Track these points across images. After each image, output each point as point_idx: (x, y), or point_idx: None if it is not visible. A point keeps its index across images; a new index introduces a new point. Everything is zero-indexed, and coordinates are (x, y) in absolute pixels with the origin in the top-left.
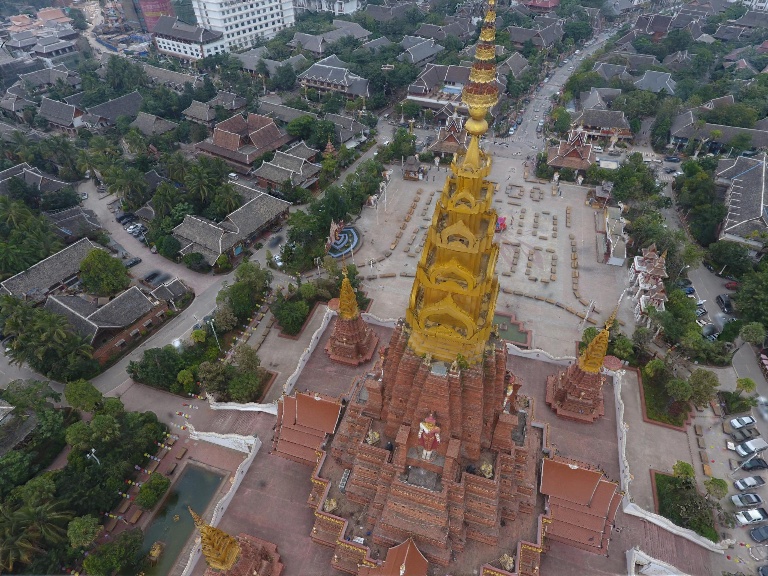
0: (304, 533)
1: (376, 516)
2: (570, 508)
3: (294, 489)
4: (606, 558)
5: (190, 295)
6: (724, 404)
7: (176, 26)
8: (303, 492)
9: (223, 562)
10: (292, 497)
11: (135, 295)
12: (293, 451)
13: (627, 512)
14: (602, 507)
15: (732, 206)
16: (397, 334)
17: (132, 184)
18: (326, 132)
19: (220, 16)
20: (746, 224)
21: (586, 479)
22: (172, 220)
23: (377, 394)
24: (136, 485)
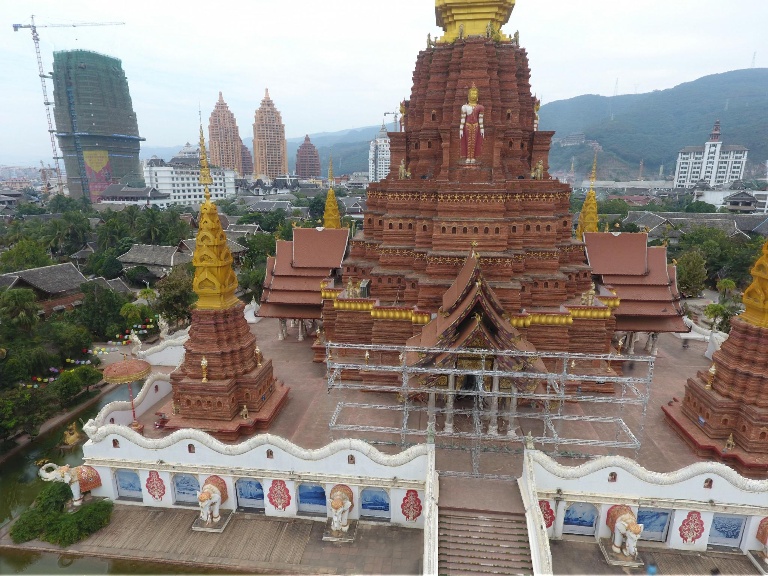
0: (311, 376)
1: (417, 277)
2: (629, 283)
3: (289, 355)
4: (688, 359)
5: (132, 296)
6: (716, 300)
7: (125, 189)
8: (302, 355)
9: (222, 284)
10: (288, 359)
11: (69, 270)
12: (289, 299)
13: (684, 336)
14: (660, 275)
15: (641, 226)
16: (420, 59)
17: (74, 227)
18: (276, 220)
19: (169, 181)
20: (658, 228)
21: (633, 245)
22: (116, 250)
23: (401, 147)
24: (50, 380)
